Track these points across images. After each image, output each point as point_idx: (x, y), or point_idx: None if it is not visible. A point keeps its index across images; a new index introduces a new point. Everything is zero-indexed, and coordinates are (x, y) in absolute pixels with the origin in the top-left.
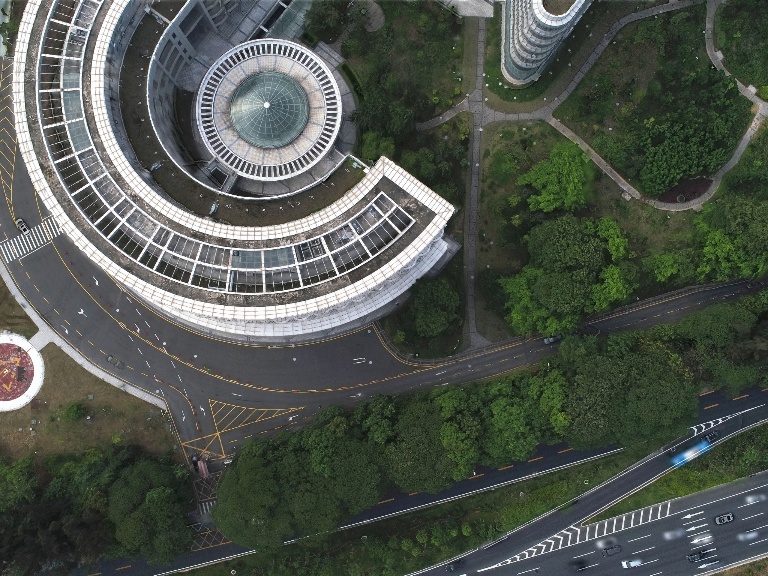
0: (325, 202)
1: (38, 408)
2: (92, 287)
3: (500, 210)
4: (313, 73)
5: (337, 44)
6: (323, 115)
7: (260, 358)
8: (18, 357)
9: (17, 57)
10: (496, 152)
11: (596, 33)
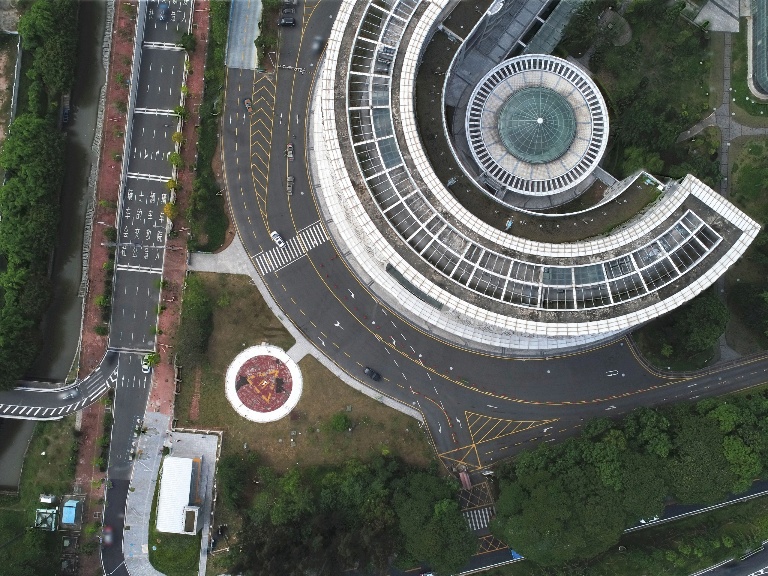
0: (618, 218)
1: (297, 419)
2: (348, 299)
3: (764, 225)
4: (579, 88)
5: (585, 58)
6: (590, 130)
7: (515, 370)
8: (276, 369)
9: (326, 75)
10: (745, 166)
11: None
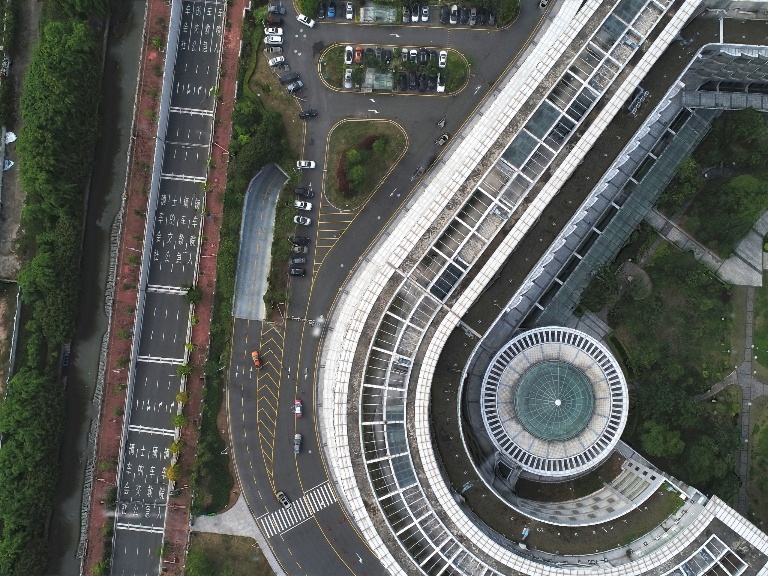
0: (638, 526)
1: None
2: (356, 565)
3: None
4: (598, 362)
5: (603, 312)
6: (609, 407)
7: None
8: None
9: (339, 387)
10: (766, 428)
11: None
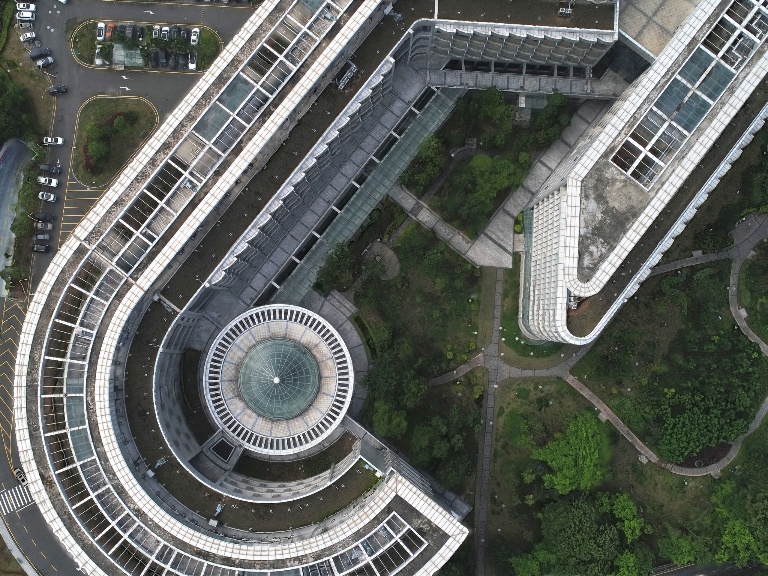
0: (335, 504)
1: None
2: None
3: (514, 488)
4: (325, 341)
5: (350, 292)
6: (334, 386)
7: None
8: None
9: (19, 359)
10: (511, 411)
11: None
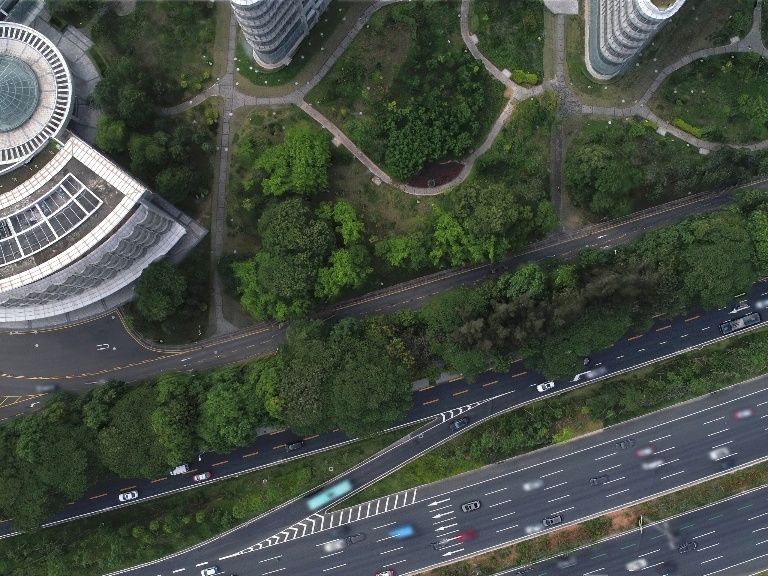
0: None
1: None
2: None
3: (233, 194)
4: (44, 56)
5: (87, 28)
6: (53, 98)
7: (2, 344)
8: None
9: None
10: (245, 137)
11: (350, 17)
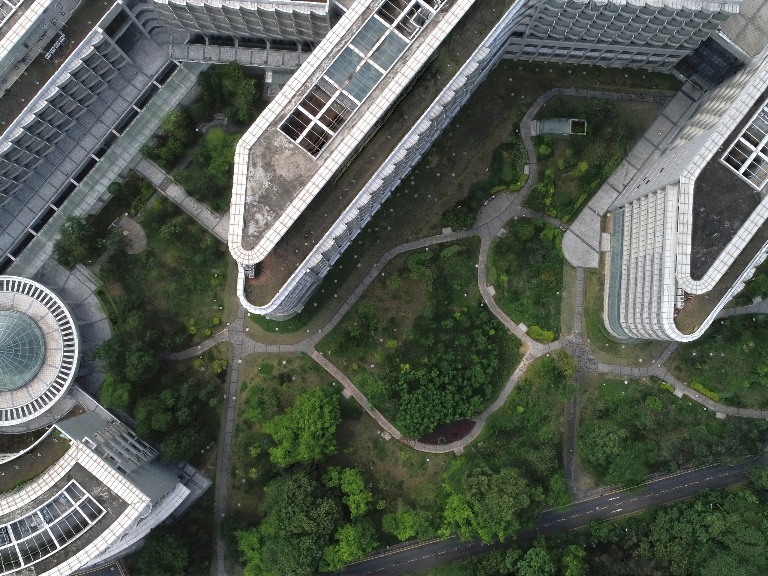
0: (30, 473)
1: None
2: None
3: (239, 461)
4: (51, 313)
5: (96, 266)
6: (59, 357)
7: None
8: None
9: None
10: (253, 386)
11: (365, 263)
